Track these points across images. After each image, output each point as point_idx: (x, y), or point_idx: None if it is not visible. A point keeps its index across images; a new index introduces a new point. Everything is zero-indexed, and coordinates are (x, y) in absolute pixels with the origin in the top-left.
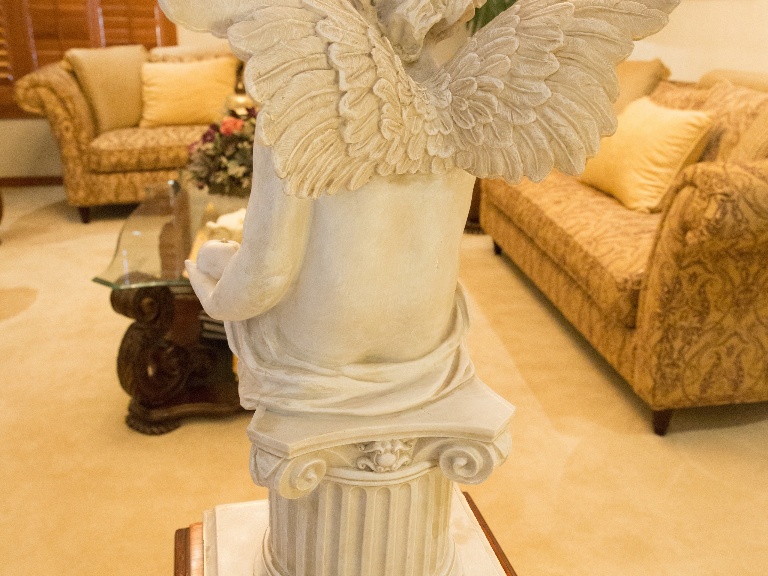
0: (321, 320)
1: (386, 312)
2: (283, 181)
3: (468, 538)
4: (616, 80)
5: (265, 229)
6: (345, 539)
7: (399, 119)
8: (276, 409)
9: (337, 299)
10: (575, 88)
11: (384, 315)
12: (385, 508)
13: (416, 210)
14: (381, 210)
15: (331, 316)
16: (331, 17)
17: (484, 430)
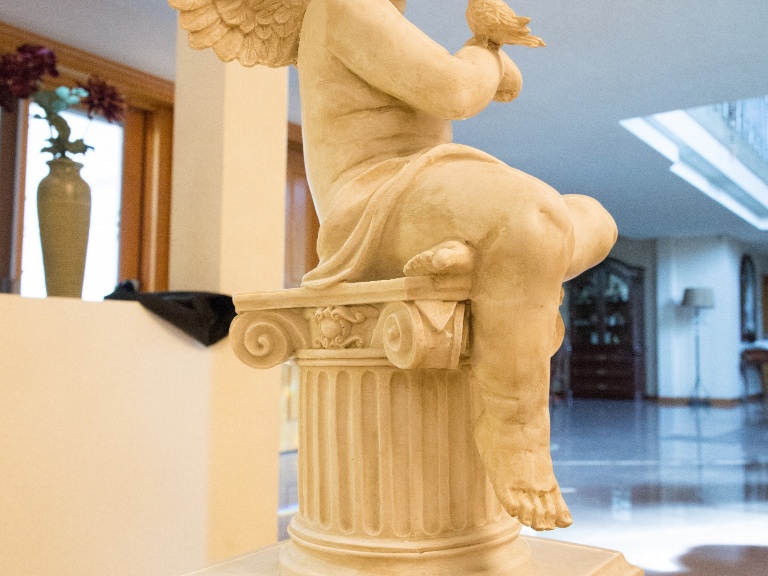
0: None
1: None
2: None
3: None
4: None
5: None
6: None
7: None
8: None
9: None
10: None
11: None
12: None
13: None
14: None
15: None
16: None
17: None
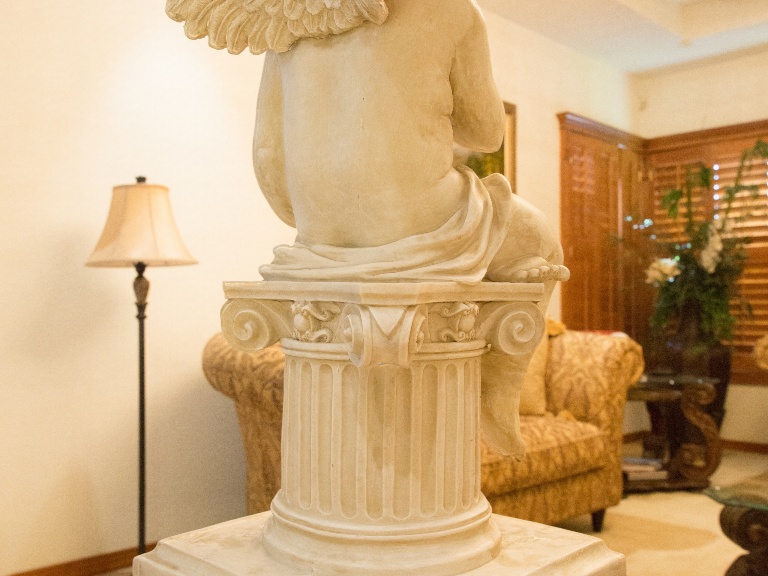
0: None
1: (325, 176)
2: None
3: (519, 565)
4: None
5: None
6: (287, 422)
7: None
8: None
9: (287, 162)
10: None
11: (324, 180)
12: None
13: (338, 70)
14: (306, 71)
15: (289, 182)
16: None
17: None
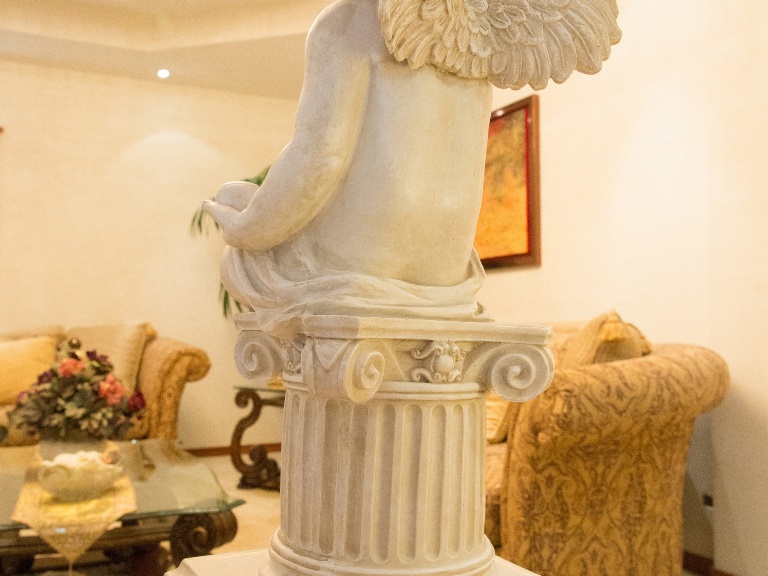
0: (372, 214)
1: (432, 211)
2: None
3: None
4: (614, 0)
5: (326, 106)
6: (399, 475)
7: None
8: (327, 310)
9: (391, 185)
10: None
11: (430, 215)
12: (439, 434)
13: (457, 111)
14: (431, 99)
15: (383, 207)
16: None
17: (536, 328)
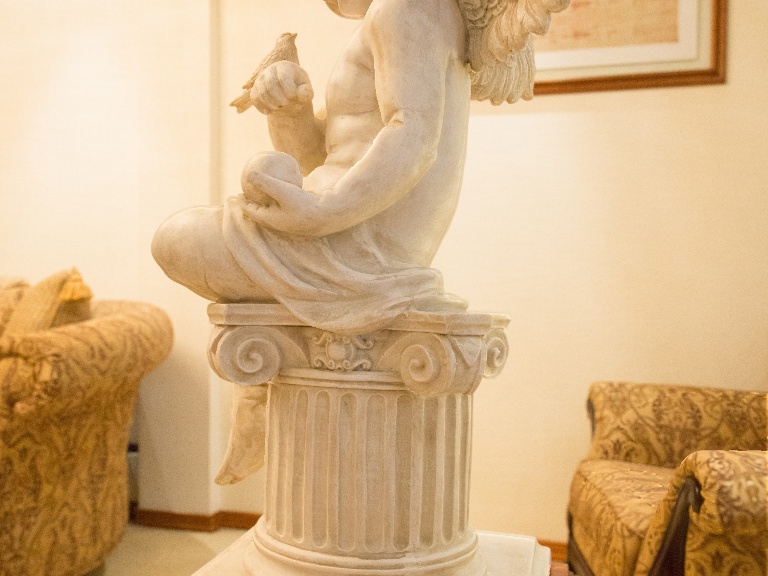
0: (438, 208)
1: None
2: (549, 18)
3: None
4: None
5: (436, 96)
6: None
7: None
8: (429, 305)
9: (456, 182)
10: None
11: None
12: None
13: None
14: None
15: (447, 202)
16: None
17: (507, 314)
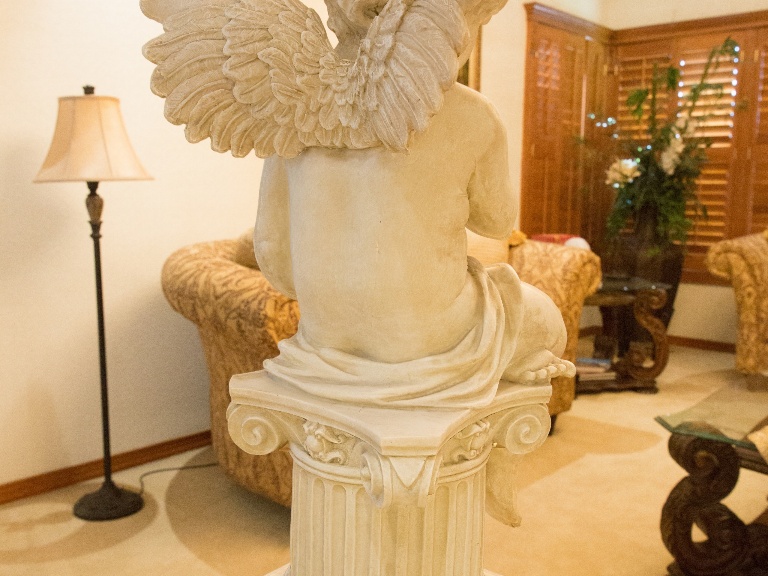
0: (296, 291)
1: (337, 291)
2: None
3: None
4: (458, 21)
5: None
6: (297, 526)
7: (295, 85)
8: None
9: (295, 268)
10: (412, 34)
11: (336, 295)
12: (323, 505)
13: (353, 187)
14: (318, 182)
15: (297, 286)
16: (243, 2)
17: (375, 436)
